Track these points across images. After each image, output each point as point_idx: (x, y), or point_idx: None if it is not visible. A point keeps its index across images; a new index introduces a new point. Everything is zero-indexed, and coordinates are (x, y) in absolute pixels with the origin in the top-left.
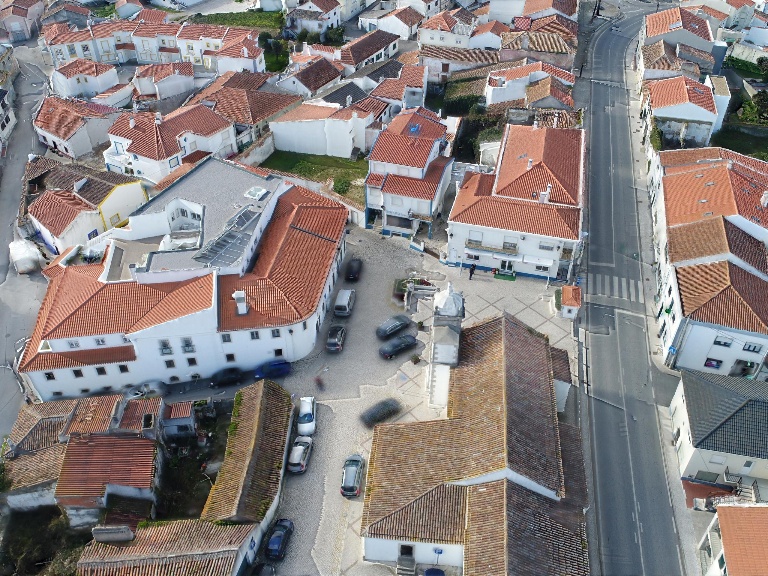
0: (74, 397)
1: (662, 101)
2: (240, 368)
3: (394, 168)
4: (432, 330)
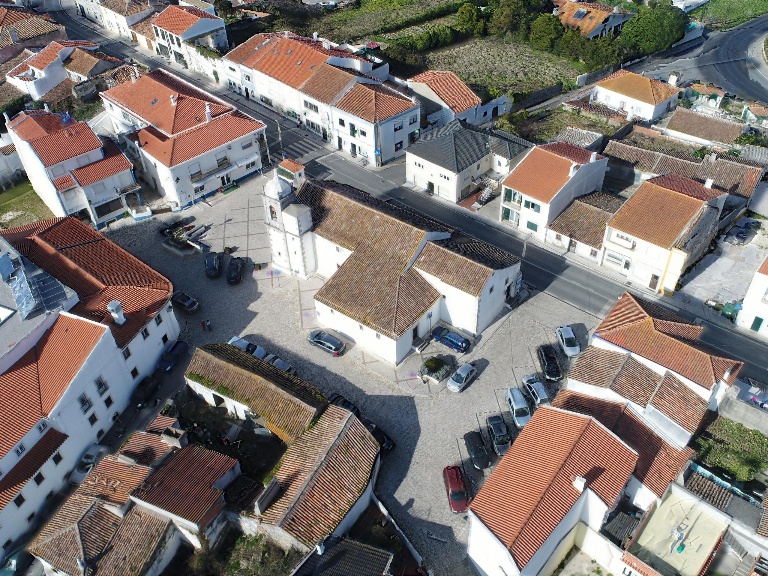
0: (27, 531)
1: (179, 27)
2: (147, 376)
3: (73, 163)
4: (281, 216)
